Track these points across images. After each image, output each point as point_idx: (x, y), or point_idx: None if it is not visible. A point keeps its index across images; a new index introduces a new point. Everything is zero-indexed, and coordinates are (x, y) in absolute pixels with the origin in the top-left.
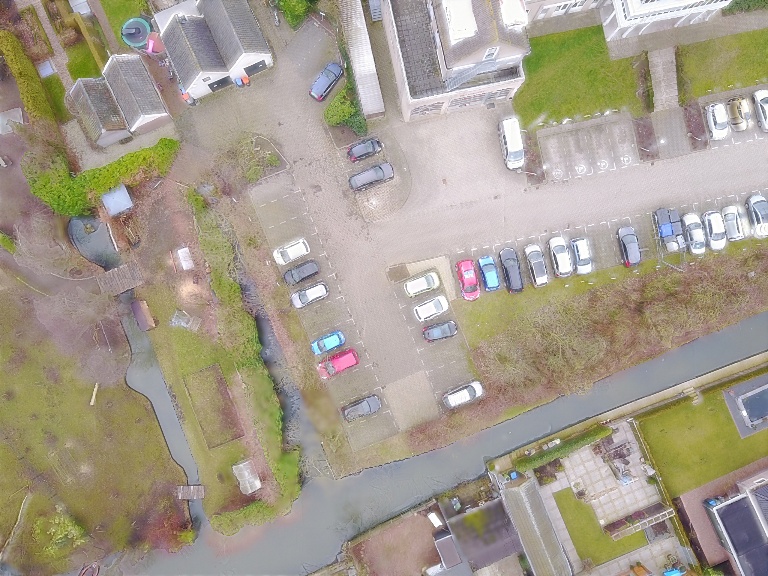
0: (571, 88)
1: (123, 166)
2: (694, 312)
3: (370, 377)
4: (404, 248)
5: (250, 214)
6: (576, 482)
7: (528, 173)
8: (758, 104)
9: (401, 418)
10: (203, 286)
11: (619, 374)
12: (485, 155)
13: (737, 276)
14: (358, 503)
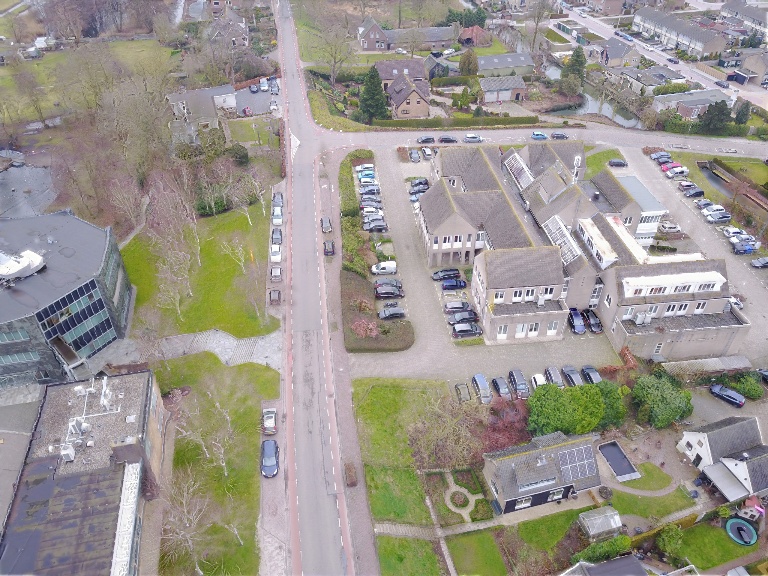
0: None
1: None
2: None
3: None
4: None
5: None
6: None
7: None
8: None
9: None
10: None
11: None
12: None
13: None
14: None
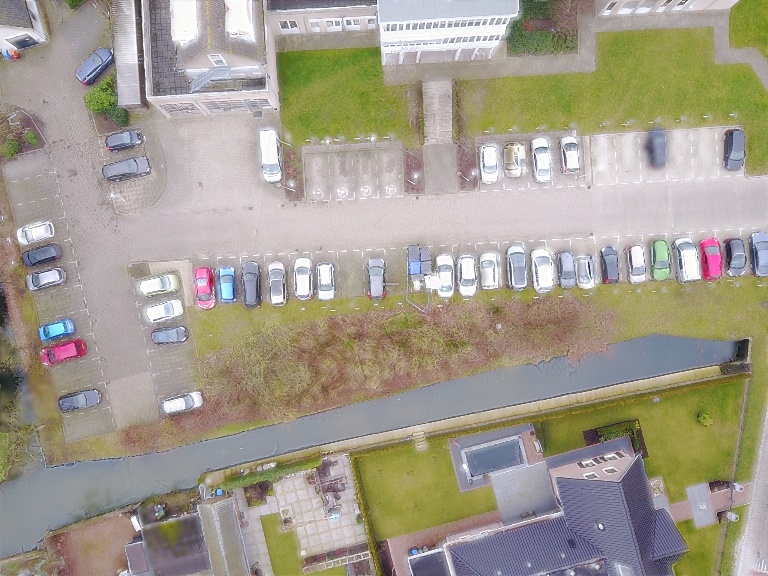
0: (341, 108)
1: None
2: (408, 356)
3: (96, 370)
4: (150, 246)
5: None
6: (285, 509)
7: (287, 188)
8: (532, 152)
9: (120, 416)
10: None
11: (352, 407)
12: (246, 164)
13: (460, 326)
14: (108, 493)
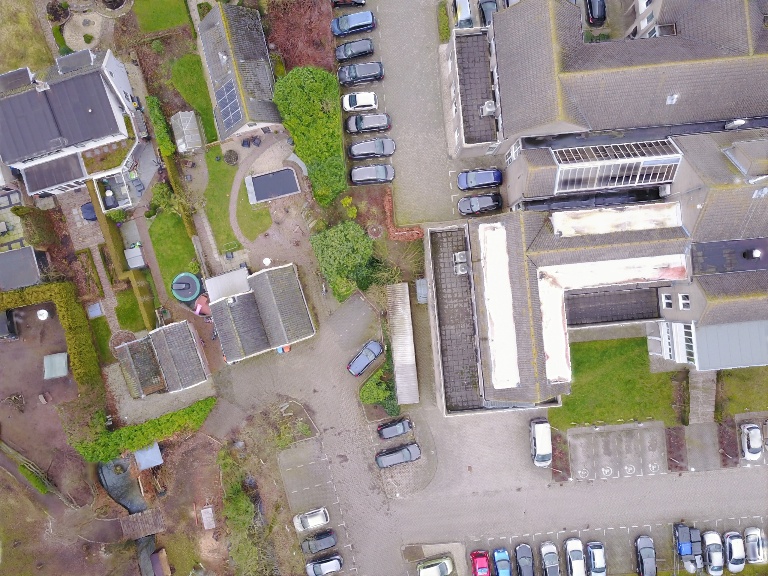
0: (607, 394)
1: (158, 430)
2: None
3: None
4: (422, 528)
5: (275, 477)
6: None
7: (554, 470)
8: None
9: None
10: (222, 541)
11: None
12: (513, 447)
13: None
14: None
